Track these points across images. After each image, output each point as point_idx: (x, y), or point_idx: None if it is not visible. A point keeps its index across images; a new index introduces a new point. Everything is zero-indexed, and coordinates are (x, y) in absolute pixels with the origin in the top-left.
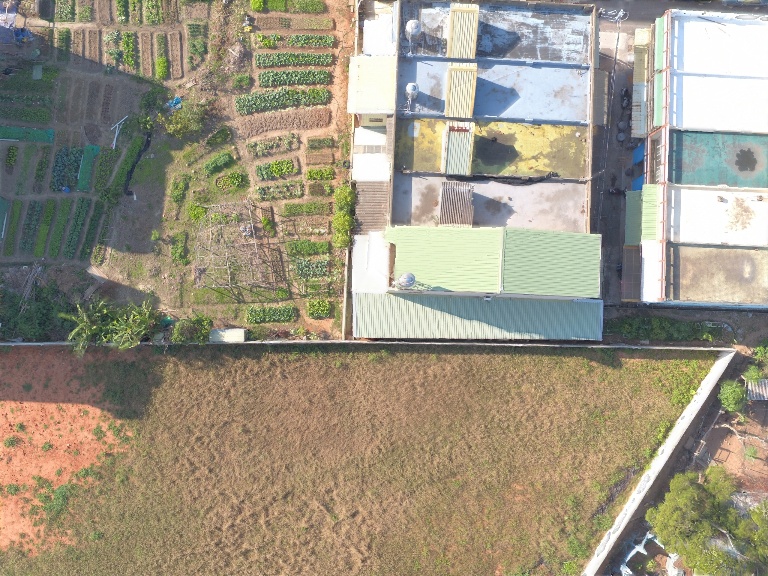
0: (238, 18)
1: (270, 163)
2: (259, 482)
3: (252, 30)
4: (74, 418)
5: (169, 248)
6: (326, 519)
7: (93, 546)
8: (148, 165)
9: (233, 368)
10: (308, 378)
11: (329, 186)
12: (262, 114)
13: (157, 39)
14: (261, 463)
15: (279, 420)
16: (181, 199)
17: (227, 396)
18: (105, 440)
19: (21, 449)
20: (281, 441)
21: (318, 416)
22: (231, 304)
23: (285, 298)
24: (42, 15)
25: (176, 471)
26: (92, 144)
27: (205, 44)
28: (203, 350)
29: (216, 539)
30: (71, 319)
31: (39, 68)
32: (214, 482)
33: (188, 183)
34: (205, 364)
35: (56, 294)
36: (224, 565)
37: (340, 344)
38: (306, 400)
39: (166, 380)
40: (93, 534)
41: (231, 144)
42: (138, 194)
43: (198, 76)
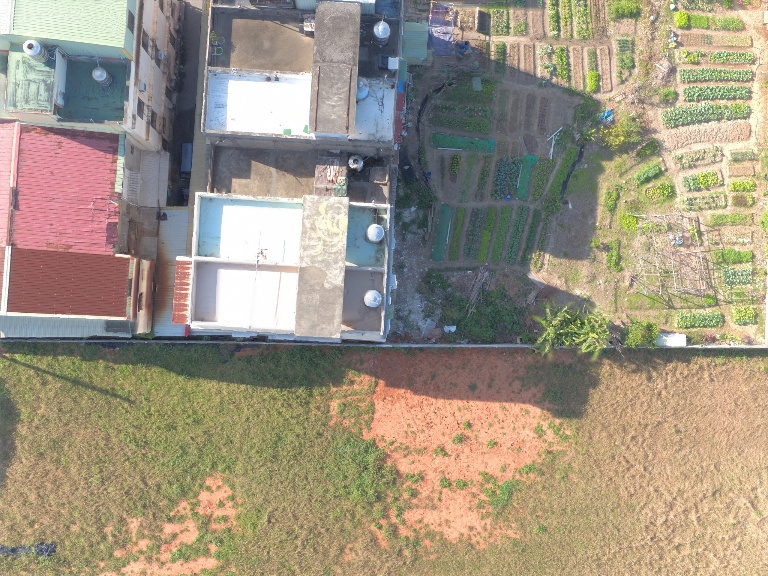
0: (664, 34)
1: (696, 175)
2: (690, 480)
3: (676, 46)
4: (516, 417)
5: (603, 255)
6: (750, 515)
7: (537, 539)
8: (582, 175)
9: (665, 371)
10: (732, 381)
11: (751, 198)
12: (687, 127)
13: (588, 53)
14: (691, 462)
15: (707, 421)
16: (613, 208)
17: (659, 397)
18: (545, 438)
19: (468, 446)
20: (709, 441)
21: (742, 417)
22: (661, 310)
23: (712, 304)
24: (479, 28)
25: (613, 468)
26: (529, 154)
27: (632, 59)
28: (636, 353)
29: (651, 534)
30: (519, 322)
31: (478, 80)
32: (648, 479)
33: (619, 193)
34: (638, 367)
35: (504, 298)
36: (659, 558)
37: (761, 349)
38: (732, 402)
39: (603, 382)
40: (538, 528)
41: (658, 156)
42: (573, 203)
43: (628, 90)
